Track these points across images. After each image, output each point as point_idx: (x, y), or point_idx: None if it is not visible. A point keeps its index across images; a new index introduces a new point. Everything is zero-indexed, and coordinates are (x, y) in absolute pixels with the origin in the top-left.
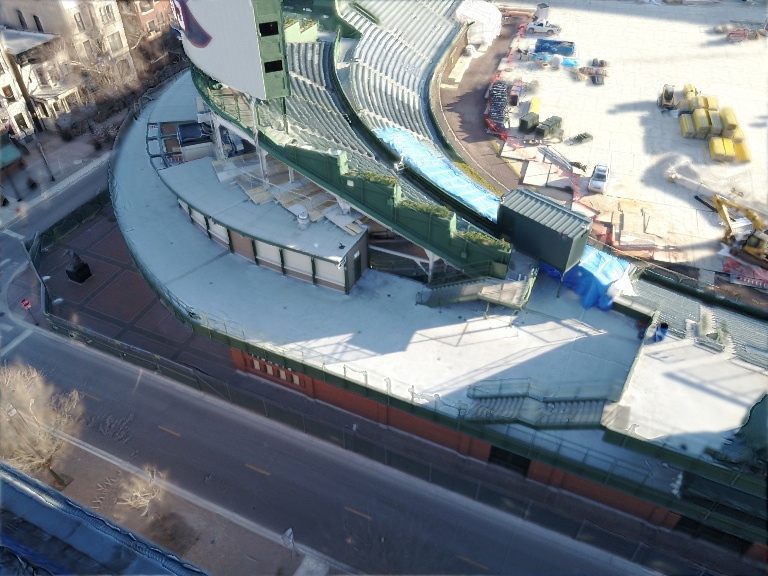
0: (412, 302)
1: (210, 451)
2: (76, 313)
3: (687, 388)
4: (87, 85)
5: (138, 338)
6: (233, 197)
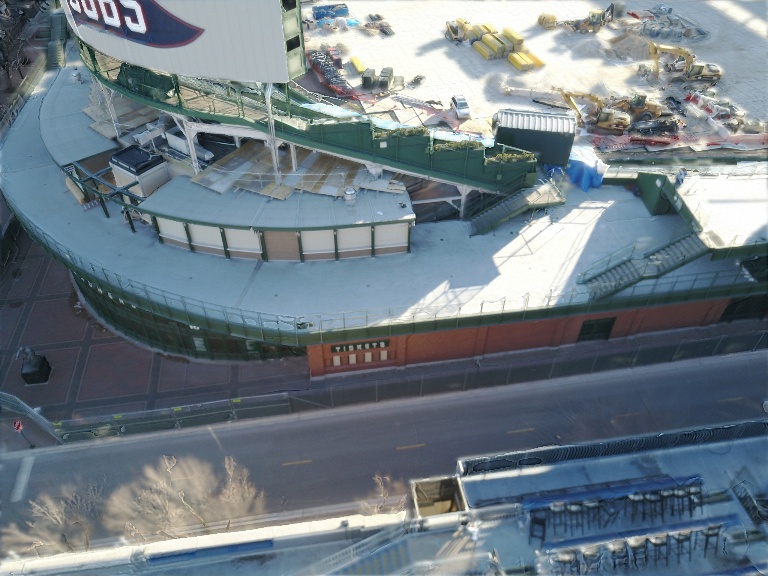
0: (466, 237)
1: (355, 456)
2: (72, 413)
3: (725, 205)
4: None
5: (175, 401)
6: (251, 202)
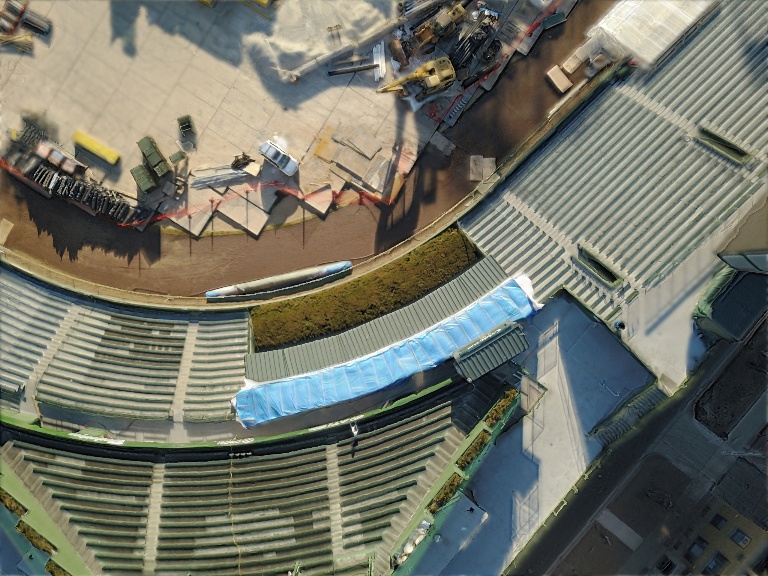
0: (492, 447)
1: (510, 570)
2: None
3: (658, 332)
4: None
5: None
6: None
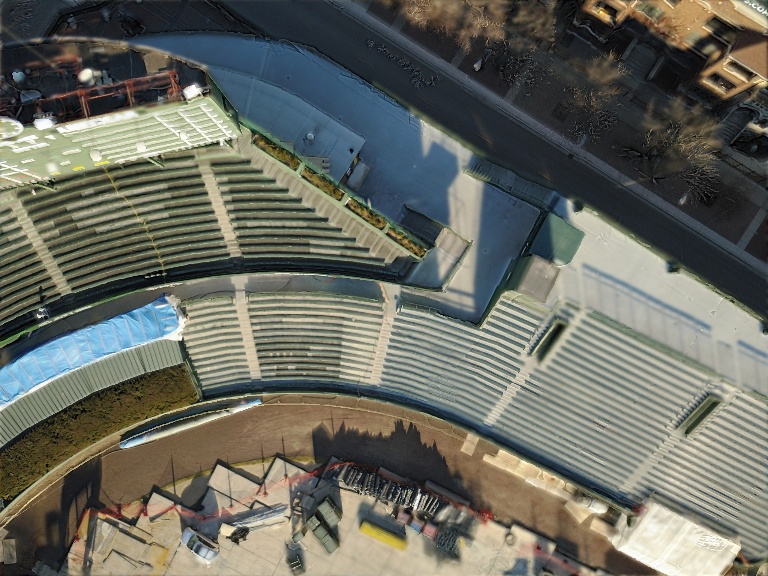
0: None
1: None
2: (89, 37)
3: None
4: None
5: None
6: None
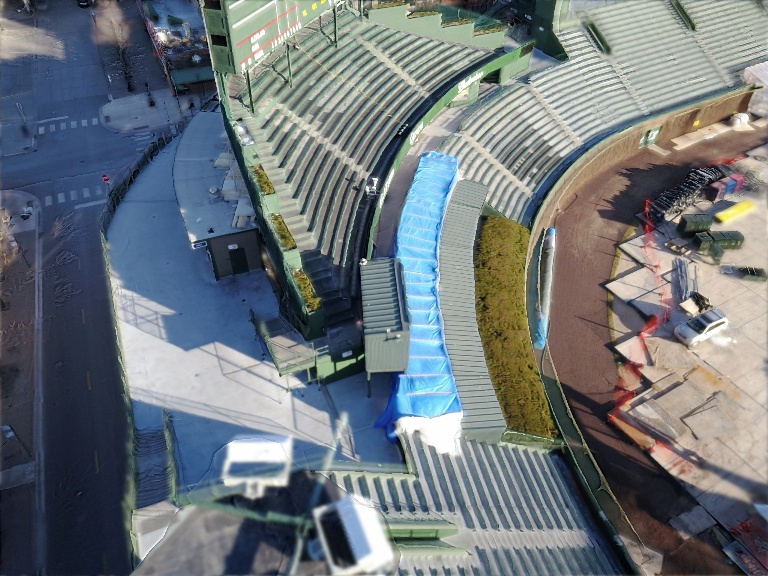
0: (249, 317)
1: (83, 346)
2: None
3: None
4: None
5: None
6: (210, 154)
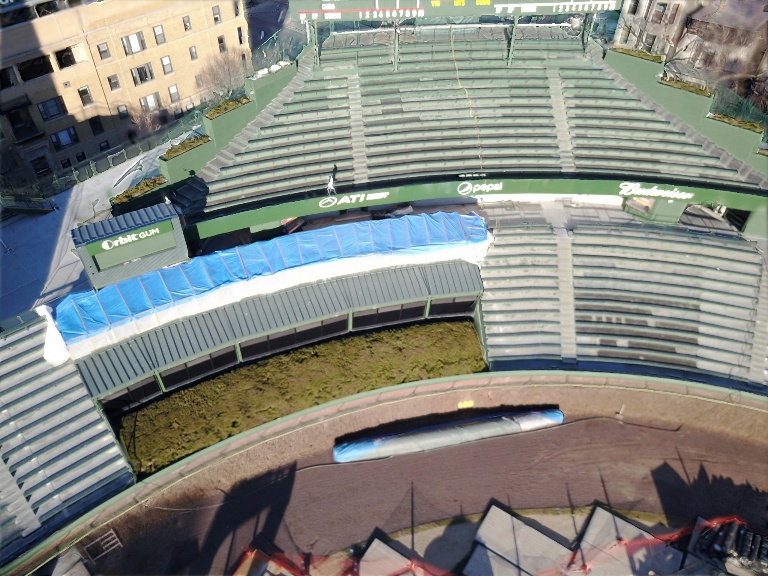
0: None
1: None
2: None
3: None
4: (720, 89)
5: None
6: None
